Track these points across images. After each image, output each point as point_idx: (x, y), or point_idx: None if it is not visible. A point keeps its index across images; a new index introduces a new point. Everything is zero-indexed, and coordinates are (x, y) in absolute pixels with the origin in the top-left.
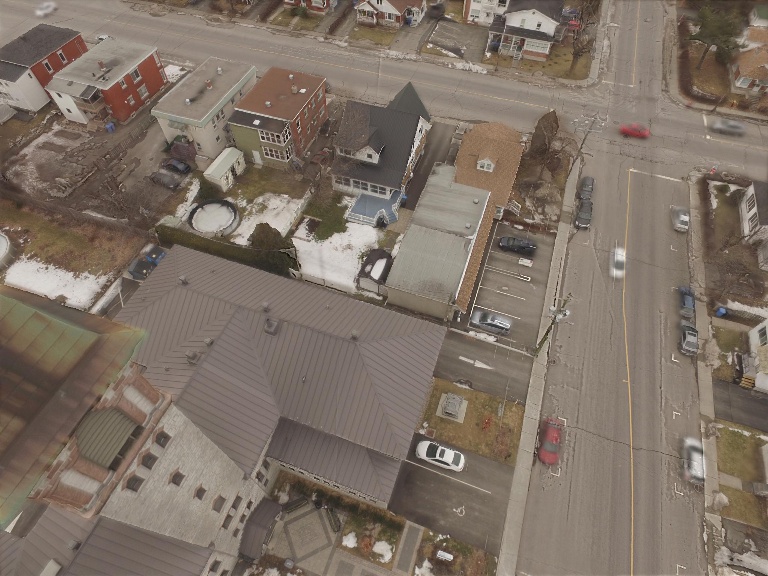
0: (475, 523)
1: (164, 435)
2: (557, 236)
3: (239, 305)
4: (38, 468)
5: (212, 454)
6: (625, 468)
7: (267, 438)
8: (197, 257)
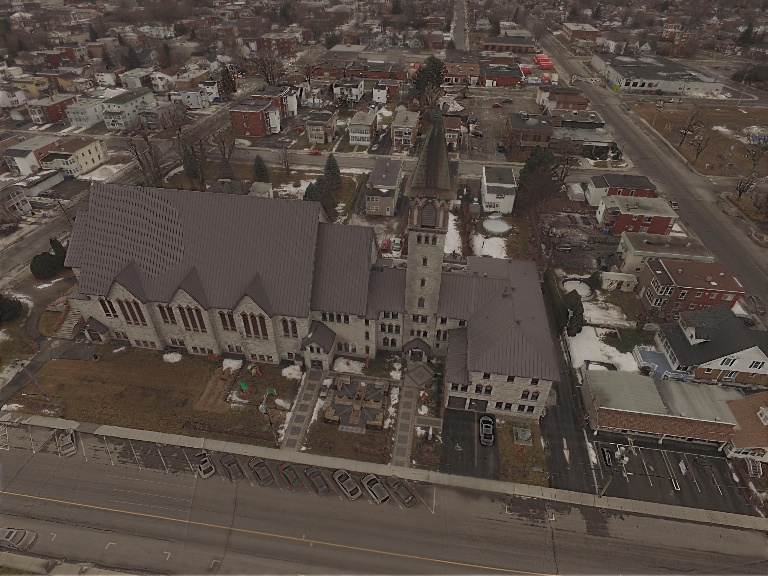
0: (454, 457)
1: (436, 241)
2: (757, 517)
3: (510, 280)
4: (416, 195)
5: (437, 277)
6: (536, 567)
7: (455, 318)
8: (532, 269)
